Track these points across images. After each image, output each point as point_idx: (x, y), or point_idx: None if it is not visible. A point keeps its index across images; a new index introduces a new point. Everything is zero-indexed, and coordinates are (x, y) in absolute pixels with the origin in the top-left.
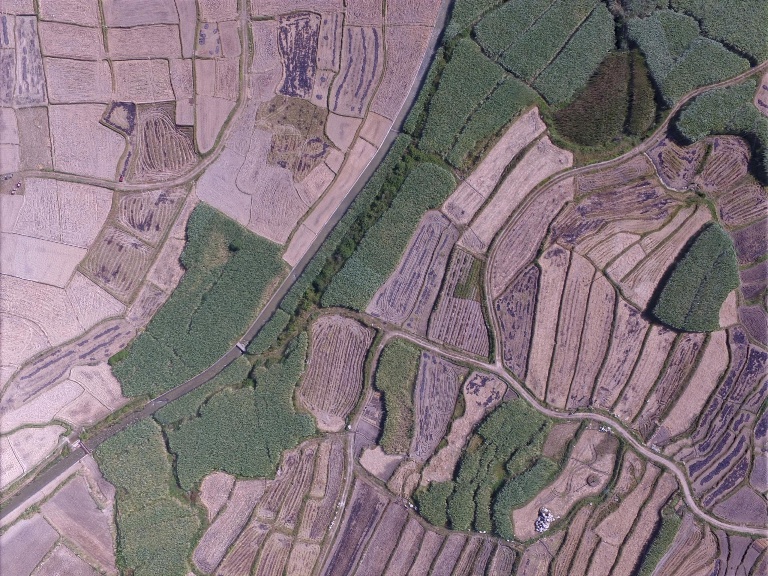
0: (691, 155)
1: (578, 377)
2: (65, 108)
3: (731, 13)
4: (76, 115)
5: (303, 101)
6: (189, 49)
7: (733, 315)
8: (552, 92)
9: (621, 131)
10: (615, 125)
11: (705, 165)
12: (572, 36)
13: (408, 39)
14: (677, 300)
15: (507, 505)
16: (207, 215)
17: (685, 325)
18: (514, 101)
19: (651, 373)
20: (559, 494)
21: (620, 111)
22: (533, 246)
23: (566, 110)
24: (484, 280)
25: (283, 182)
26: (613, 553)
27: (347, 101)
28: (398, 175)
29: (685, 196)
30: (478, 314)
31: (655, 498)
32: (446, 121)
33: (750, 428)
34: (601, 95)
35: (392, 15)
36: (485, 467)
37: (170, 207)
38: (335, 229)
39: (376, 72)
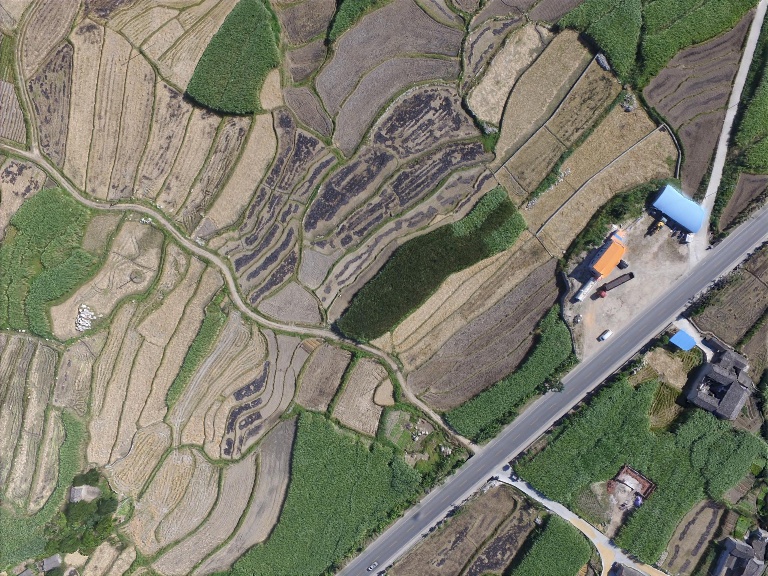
0: None
1: (119, 165)
2: None
3: None
4: None
5: None
6: None
7: (278, 96)
8: None
9: None
10: None
11: None
12: None
13: None
14: (210, 76)
15: (38, 298)
16: None
17: (220, 104)
18: None
19: (195, 161)
20: (101, 291)
21: None
22: (66, 22)
23: None
24: (14, 58)
25: None
26: (158, 354)
27: None
28: None
29: None
30: (12, 97)
31: (200, 295)
32: None
33: (298, 219)
34: None
35: None
36: (18, 259)
37: None
38: None
39: None
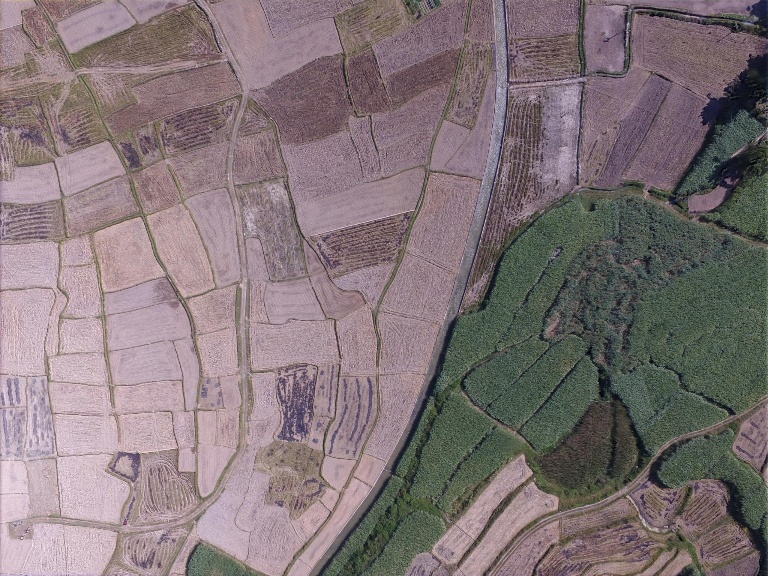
0: (672, 496)
1: None
2: (73, 459)
3: (710, 369)
4: (83, 465)
5: (300, 445)
6: (192, 403)
7: None
8: (538, 440)
9: (605, 473)
10: (599, 469)
11: (686, 507)
12: (557, 387)
13: (401, 386)
14: None
15: None
16: (207, 557)
17: None
18: (502, 452)
19: None
20: None
21: (604, 456)
22: None
23: (552, 456)
24: None
25: (280, 519)
26: None
27: (342, 445)
28: (390, 520)
29: (666, 537)
30: None
31: None
32: (437, 469)
33: None
34: (585, 442)
35: (385, 365)
36: None
37: (172, 545)
38: (330, 567)
39: (370, 418)
